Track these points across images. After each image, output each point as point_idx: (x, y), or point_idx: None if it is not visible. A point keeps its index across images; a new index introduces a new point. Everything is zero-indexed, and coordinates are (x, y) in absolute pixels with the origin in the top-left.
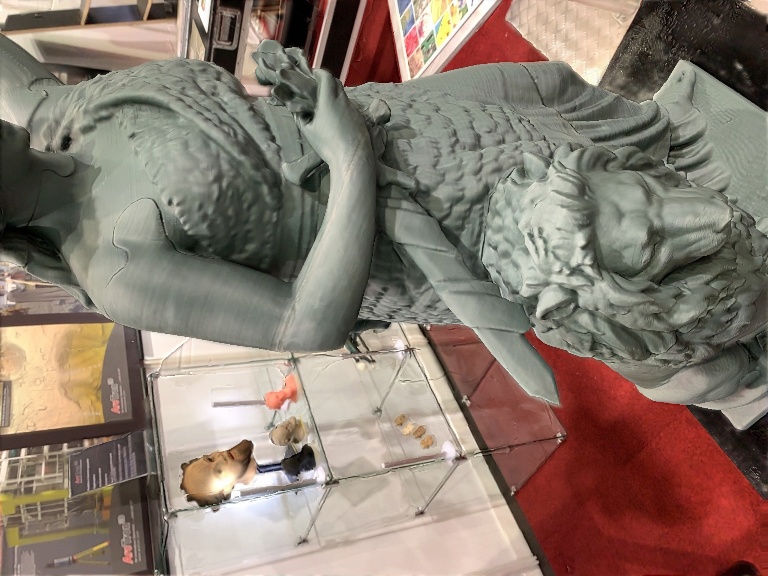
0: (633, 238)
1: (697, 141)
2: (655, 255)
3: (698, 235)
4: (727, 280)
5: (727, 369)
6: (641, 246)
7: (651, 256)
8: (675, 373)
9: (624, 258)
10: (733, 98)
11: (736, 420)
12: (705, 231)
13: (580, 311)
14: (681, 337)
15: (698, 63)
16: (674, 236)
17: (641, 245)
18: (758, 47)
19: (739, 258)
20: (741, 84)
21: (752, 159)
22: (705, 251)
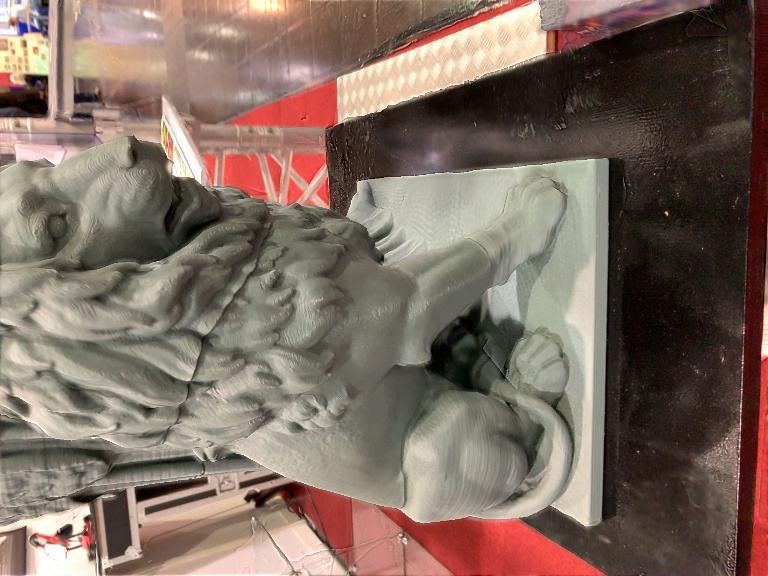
0: (7, 208)
1: (390, 232)
2: (73, 229)
3: (104, 180)
4: (233, 245)
5: (448, 418)
6: (20, 213)
7: (48, 224)
8: (401, 458)
9: (10, 239)
10: (397, 180)
11: (577, 513)
12: (109, 172)
13: (6, 343)
14: (220, 345)
15: (374, 178)
16: (81, 195)
17: (19, 212)
18: (396, 134)
19: (277, 232)
20: (404, 169)
21: (430, 216)
22: (133, 199)
